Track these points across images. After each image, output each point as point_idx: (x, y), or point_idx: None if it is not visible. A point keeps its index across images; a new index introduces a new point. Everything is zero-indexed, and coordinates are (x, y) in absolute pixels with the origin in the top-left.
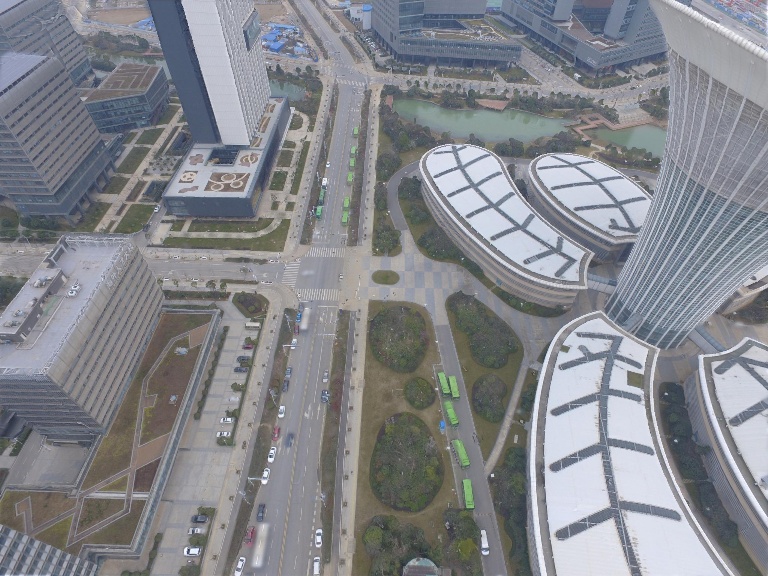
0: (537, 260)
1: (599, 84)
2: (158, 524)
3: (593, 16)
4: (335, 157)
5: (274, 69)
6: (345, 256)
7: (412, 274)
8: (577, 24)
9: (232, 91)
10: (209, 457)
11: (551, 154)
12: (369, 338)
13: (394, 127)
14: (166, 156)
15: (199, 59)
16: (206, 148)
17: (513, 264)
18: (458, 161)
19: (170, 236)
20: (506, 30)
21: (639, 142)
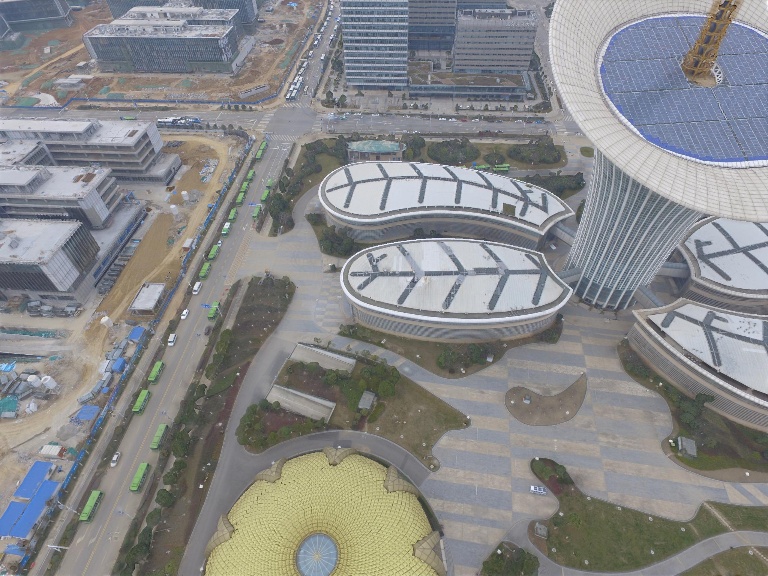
0: None
1: None
2: (422, 98)
3: None
4: None
5: None
6: None
7: None
8: None
9: None
10: (450, 106)
11: None
12: None
13: None
14: None
15: None
16: None
17: None
18: None
19: None
20: None
21: None
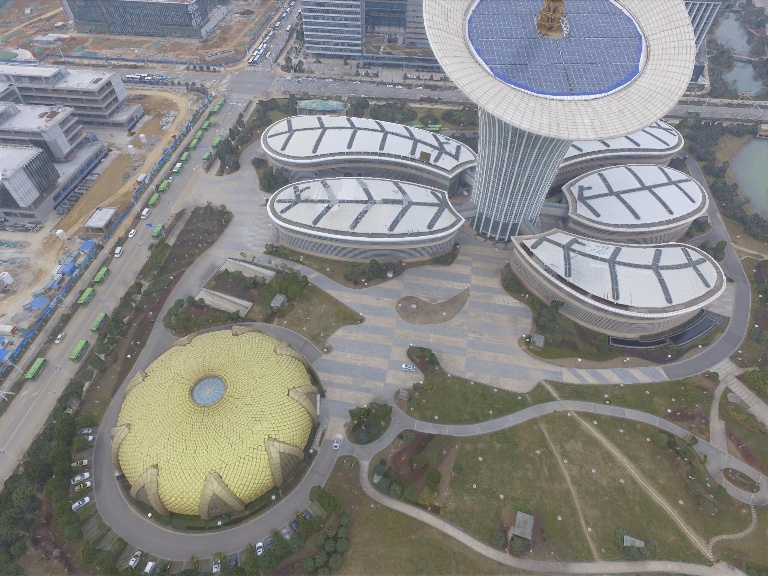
0: None
1: None
2: (374, 67)
3: None
4: None
5: None
6: None
7: None
8: None
9: None
10: (399, 75)
11: (697, 182)
12: None
13: None
14: None
15: None
16: None
17: None
18: None
19: None
20: None
21: None
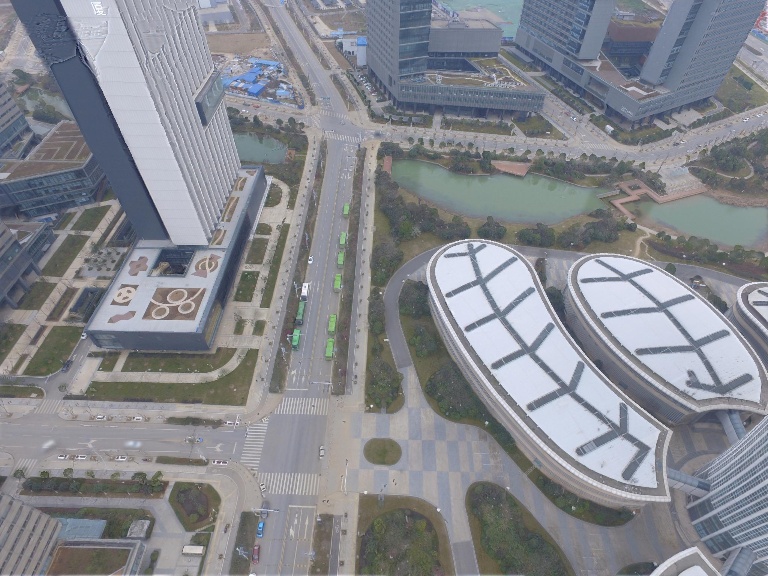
0: (595, 449)
1: (636, 139)
2: None
3: (621, 50)
4: (320, 248)
5: (252, 119)
6: (328, 413)
7: (418, 445)
8: (606, 63)
9: (179, 187)
10: None
11: (595, 256)
12: (359, 572)
13: (393, 203)
14: (107, 250)
15: (131, 151)
16: (153, 247)
17: (561, 453)
18: (477, 271)
19: (92, 390)
20: (521, 66)
21: (692, 219)
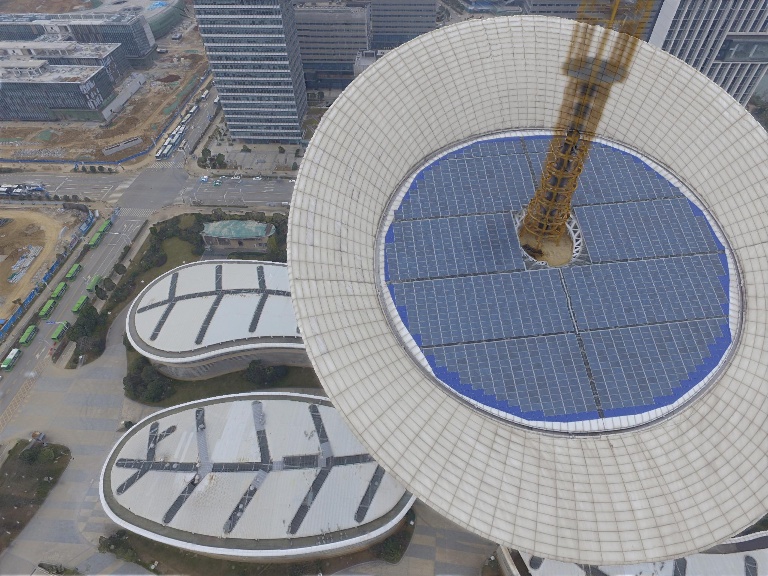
0: None
1: None
2: None
3: None
4: None
5: None
6: None
7: None
8: None
9: None
10: None
11: None
12: None
13: None
14: None
15: (652, 33)
16: None
17: None
18: None
19: None
20: None
21: None
